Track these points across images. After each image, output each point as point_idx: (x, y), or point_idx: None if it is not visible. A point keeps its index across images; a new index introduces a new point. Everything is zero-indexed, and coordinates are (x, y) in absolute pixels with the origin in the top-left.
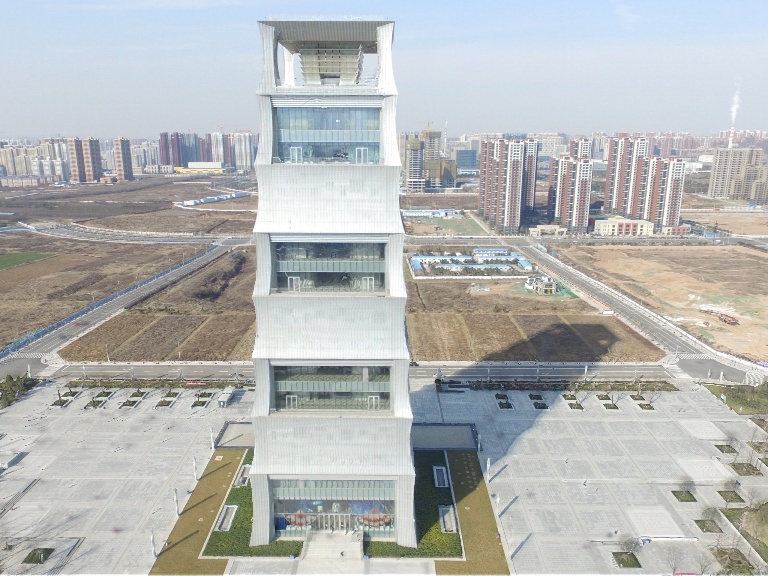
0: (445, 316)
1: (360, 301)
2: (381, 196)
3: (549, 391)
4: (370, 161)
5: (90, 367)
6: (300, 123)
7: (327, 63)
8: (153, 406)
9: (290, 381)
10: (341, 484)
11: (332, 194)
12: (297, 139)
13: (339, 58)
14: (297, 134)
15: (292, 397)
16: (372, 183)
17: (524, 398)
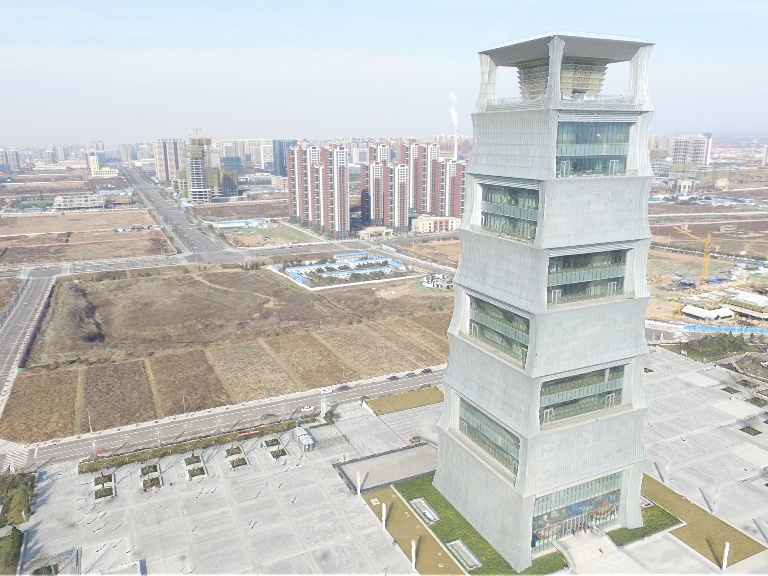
0: (395, 322)
1: (615, 306)
2: (635, 205)
3: None
4: (618, 172)
5: (71, 444)
6: (571, 137)
7: (580, 79)
8: (231, 468)
9: (549, 395)
10: (582, 486)
11: (598, 205)
12: (567, 153)
13: (589, 74)
14: (567, 148)
15: (549, 411)
16: (631, 193)
17: None
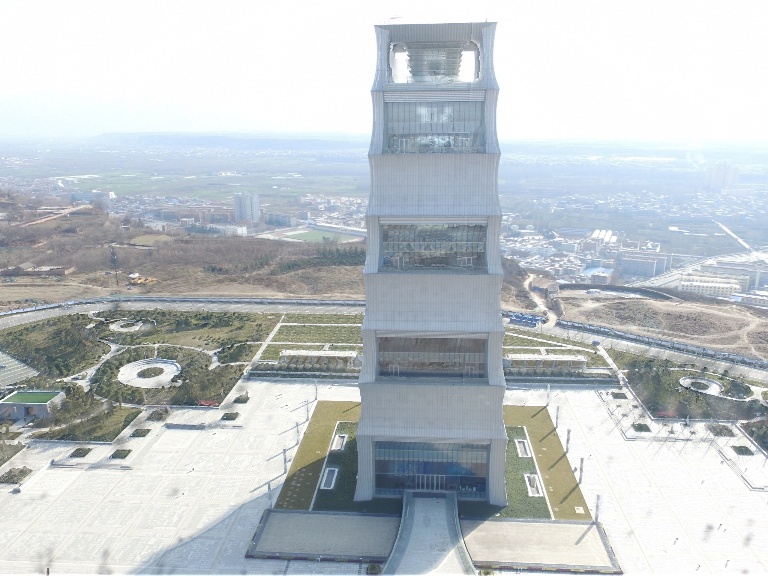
0: None
1: None
2: None
3: None
4: None
5: None
6: None
7: None
8: None
9: None
10: None
11: None
12: None
13: None
14: None
15: None
16: None
17: None
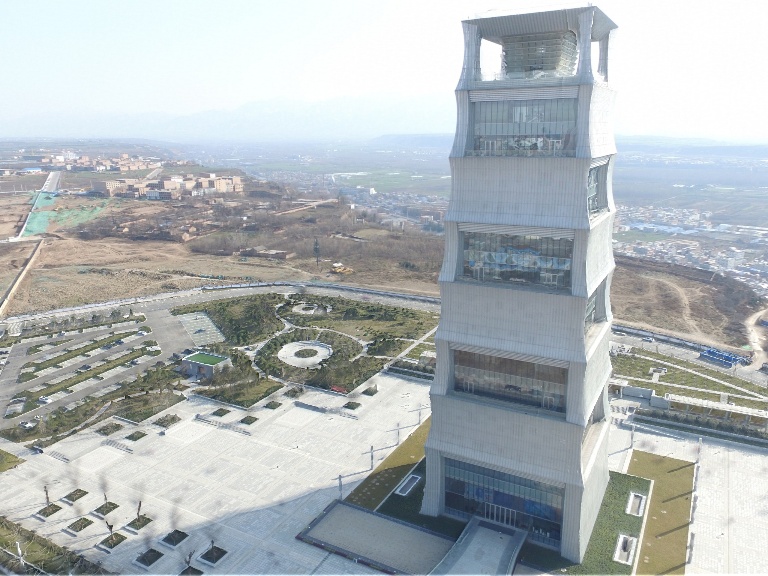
0: None
1: None
2: None
3: (107, 567)
4: None
5: None
6: None
7: None
8: None
9: None
10: None
11: None
12: None
13: None
14: None
15: None
16: None
17: (164, 564)
